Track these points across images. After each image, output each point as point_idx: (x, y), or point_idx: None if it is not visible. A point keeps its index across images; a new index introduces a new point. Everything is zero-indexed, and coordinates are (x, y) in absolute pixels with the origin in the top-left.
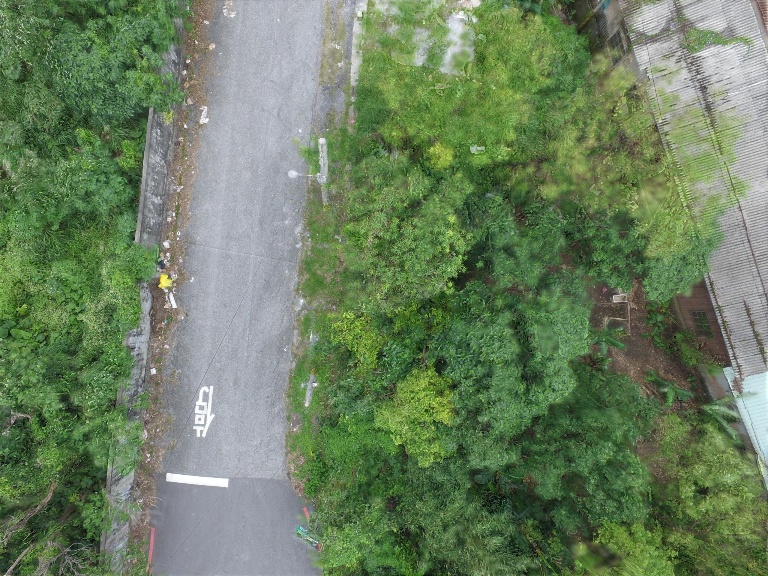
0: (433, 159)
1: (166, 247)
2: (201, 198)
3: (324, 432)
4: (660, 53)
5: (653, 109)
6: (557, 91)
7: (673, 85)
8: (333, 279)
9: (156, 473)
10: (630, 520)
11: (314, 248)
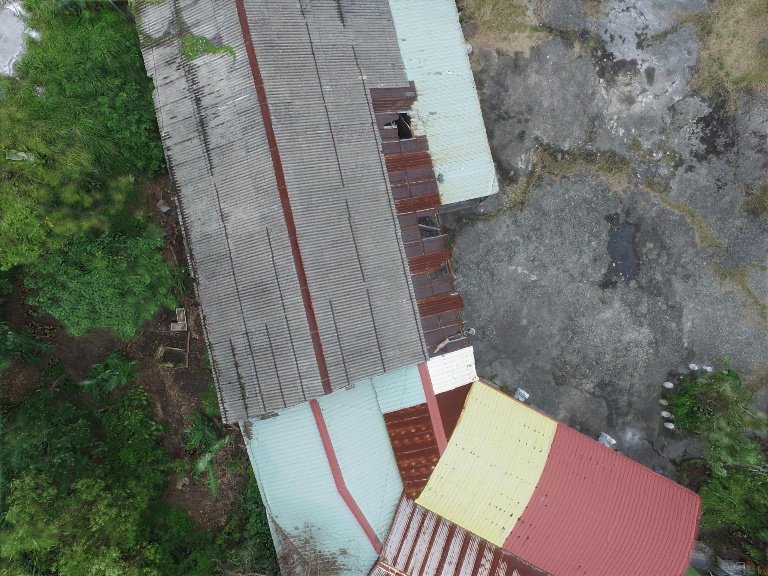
0: None
1: None
2: None
3: None
4: (163, 58)
5: (157, 120)
6: (97, 95)
7: (174, 95)
8: None
9: None
10: None
11: None
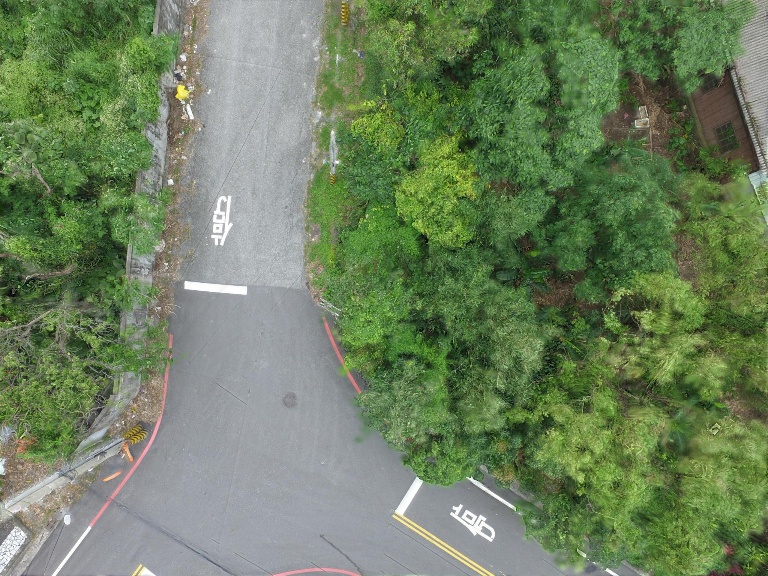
0: None
1: (183, 60)
2: (218, 11)
3: (343, 238)
4: None
5: None
6: None
7: None
8: (351, 92)
9: (174, 281)
10: (659, 268)
11: (332, 61)
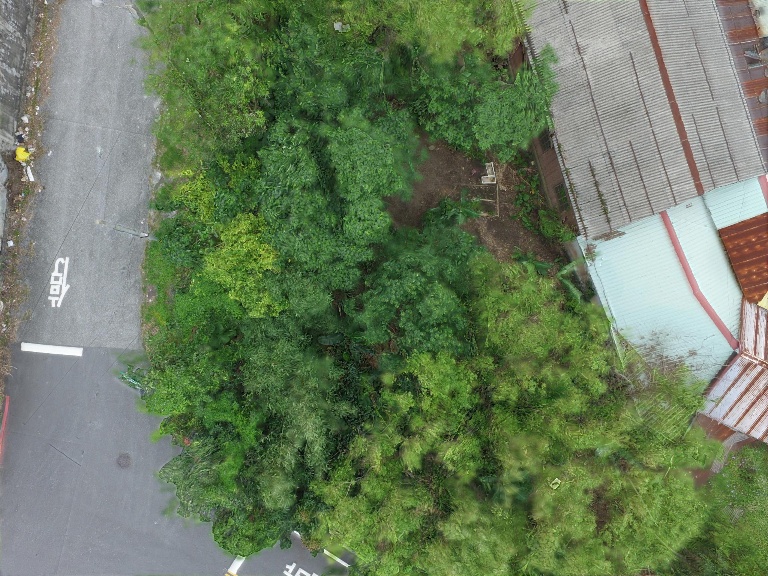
0: (292, 33)
1: (25, 122)
2: (60, 73)
3: (177, 300)
4: None
5: None
6: None
7: None
8: (192, 153)
9: (11, 343)
10: (435, 348)
11: (173, 122)
